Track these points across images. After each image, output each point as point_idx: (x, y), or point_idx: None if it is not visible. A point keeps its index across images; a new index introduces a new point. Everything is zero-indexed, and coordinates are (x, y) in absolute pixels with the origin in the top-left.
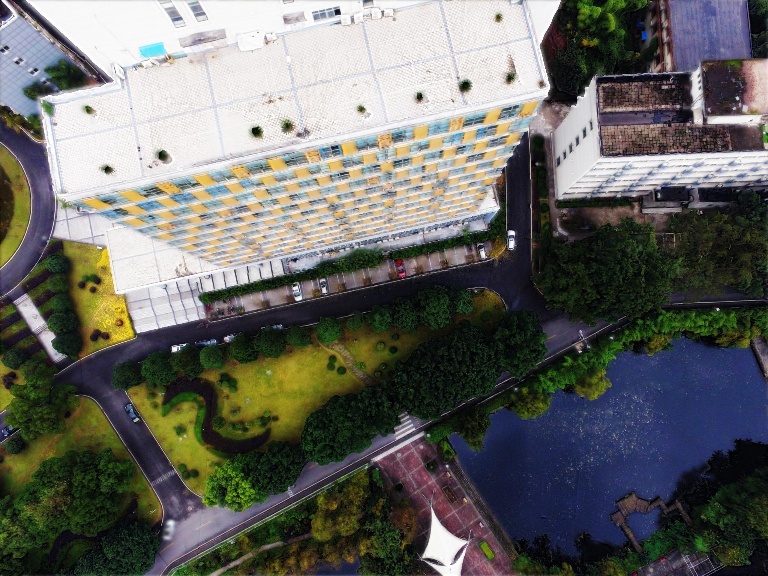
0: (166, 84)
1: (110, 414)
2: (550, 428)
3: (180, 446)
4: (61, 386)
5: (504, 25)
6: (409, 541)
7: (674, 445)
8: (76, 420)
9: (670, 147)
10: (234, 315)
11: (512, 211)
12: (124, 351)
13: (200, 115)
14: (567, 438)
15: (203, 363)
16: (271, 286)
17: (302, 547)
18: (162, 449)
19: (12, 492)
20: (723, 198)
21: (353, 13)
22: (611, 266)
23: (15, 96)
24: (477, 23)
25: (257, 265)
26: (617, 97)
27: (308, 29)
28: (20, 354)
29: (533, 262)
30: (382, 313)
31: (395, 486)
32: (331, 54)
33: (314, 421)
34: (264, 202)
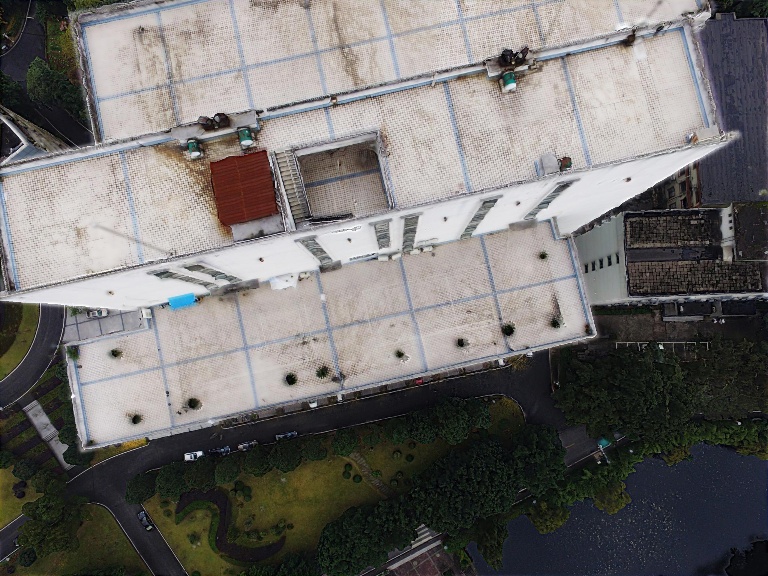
0: (195, 323)
1: (123, 521)
2: (567, 535)
3: (194, 554)
4: (73, 498)
5: (548, 262)
6: None
7: (692, 553)
8: (88, 528)
9: (699, 285)
10: (248, 422)
11: None
12: (136, 458)
13: (231, 357)
14: (584, 546)
15: (218, 482)
16: None
17: None
18: (176, 556)
19: None
20: (747, 311)
21: (391, 253)
22: (635, 398)
23: None
24: (520, 260)
25: None
26: (645, 232)
27: (343, 264)
28: (31, 465)
29: (552, 369)
30: (400, 430)
31: None
32: (367, 292)
33: (330, 536)
34: None
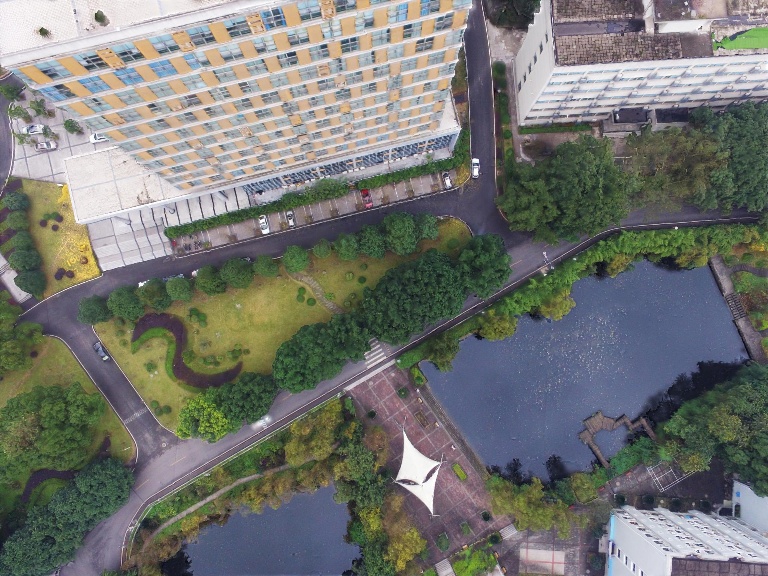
0: None
1: (79, 353)
2: (518, 352)
3: (151, 383)
4: (26, 324)
5: None
6: (382, 463)
7: (638, 364)
8: (44, 360)
9: (623, 56)
10: (201, 250)
11: (476, 139)
12: (90, 290)
13: None
14: (535, 361)
15: (170, 293)
16: (237, 219)
17: None
18: (133, 387)
19: None
20: (680, 119)
21: None
22: (570, 179)
23: None
24: None
25: (222, 197)
26: (571, 7)
27: None
28: None
29: (498, 189)
30: (348, 239)
31: (368, 413)
32: None
33: (284, 350)
34: (214, 92)
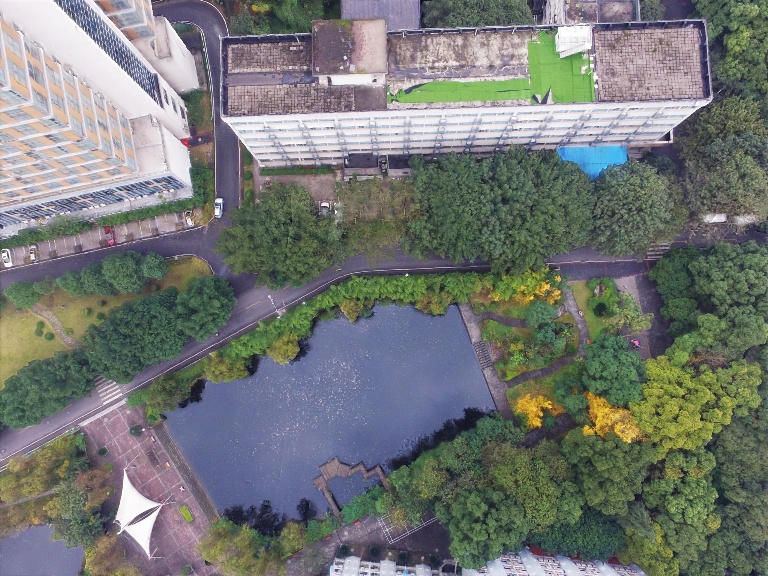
0: None
1: None
2: (258, 394)
3: None
4: None
5: None
6: (96, 503)
7: (379, 411)
8: None
9: (294, 107)
10: None
11: (221, 179)
12: None
13: None
14: (274, 404)
15: None
16: None
17: None
18: None
19: None
20: None
21: None
22: (256, 227)
23: None
24: None
25: None
26: (246, 58)
27: None
28: None
29: None
30: (66, 277)
31: (99, 450)
32: None
33: (6, 384)
34: None
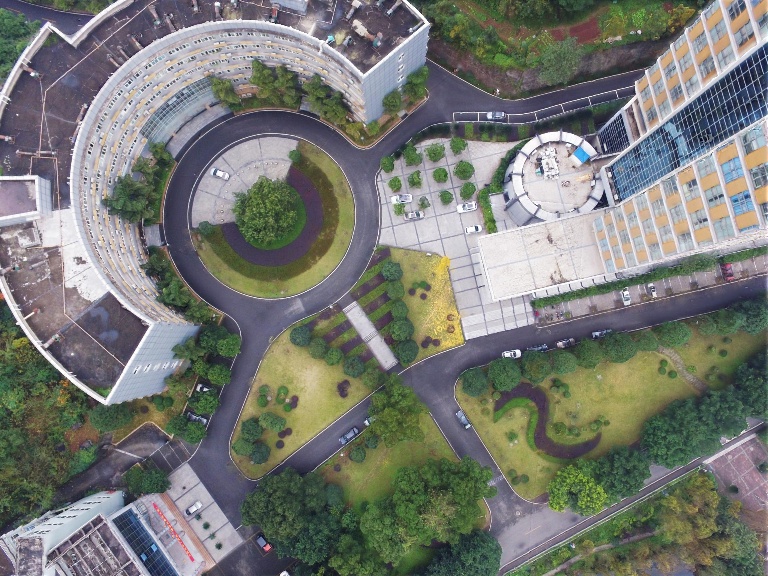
0: None
1: (440, 421)
2: None
3: (511, 452)
4: None
5: None
6: None
7: None
8: None
9: None
10: (562, 320)
11: None
12: (453, 358)
13: None
14: None
15: (567, 369)
16: (605, 291)
17: (631, 550)
18: (491, 455)
19: (351, 500)
20: None
21: None
22: None
23: (376, 103)
24: None
25: None
26: None
27: None
28: (361, 362)
29: None
30: (739, 317)
31: (730, 488)
32: None
33: (664, 425)
34: None
